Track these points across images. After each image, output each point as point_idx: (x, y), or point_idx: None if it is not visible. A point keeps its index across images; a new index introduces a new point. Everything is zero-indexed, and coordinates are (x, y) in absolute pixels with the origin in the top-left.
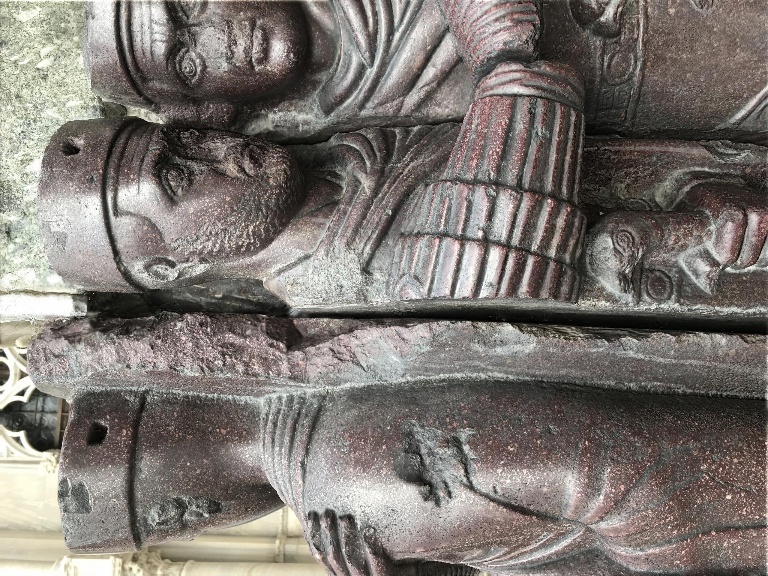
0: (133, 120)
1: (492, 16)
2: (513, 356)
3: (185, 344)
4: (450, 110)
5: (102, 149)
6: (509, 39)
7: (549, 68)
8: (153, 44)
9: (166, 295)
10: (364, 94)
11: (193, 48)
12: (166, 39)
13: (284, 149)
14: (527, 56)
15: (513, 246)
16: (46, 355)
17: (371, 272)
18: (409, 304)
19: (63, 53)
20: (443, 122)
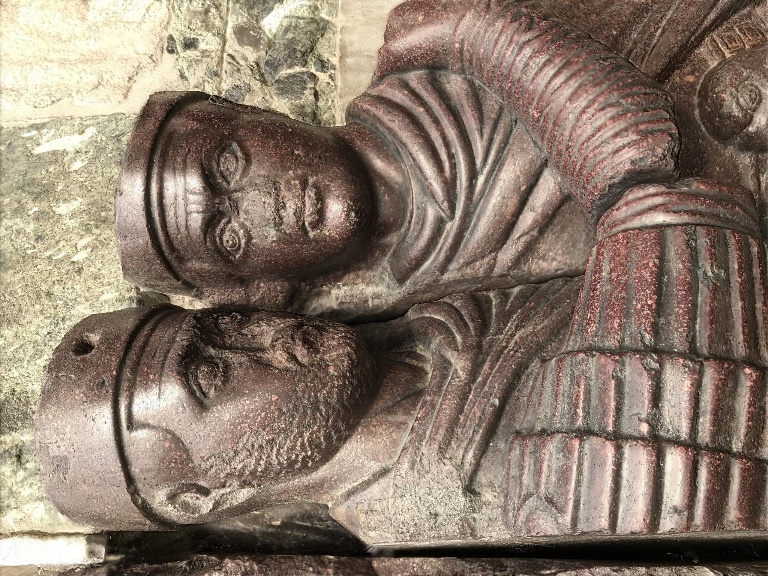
0: (165, 307)
1: (609, 132)
2: None
3: None
4: (559, 262)
5: (119, 345)
6: (638, 156)
7: (704, 186)
8: (188, 217)
9: (211, 524)
10: (446, 253)
11: (236, 218)
12: (203, 209)
13: (347, 327)
14: (665, 176)
15: (702, 445)
16: None
17: (477, 491)
18: (539, 538)
19: (101, 243)
20: (551, 278)
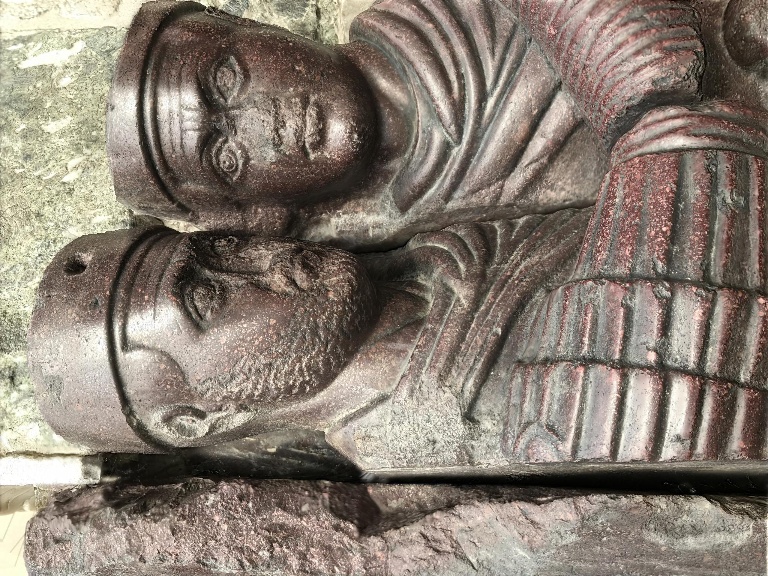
0: (159, 229)
1: (631, 49)
2: (714, 550)
3: (218, 527)
4: (567, 193)
5: (112, 265)
6: (660, 76)
7: (728, 108)
8: (184, 135)
9: (207, 450)
10: (451, 180)
11: (233, 137)
12: (199, 127)
13: (348, 253)
14: (687, 99)
15: (710, 375)
16: (45, 539)
17: (477, 419)
18: (536, 466)
19: (92, 163)
20: (558, 209)
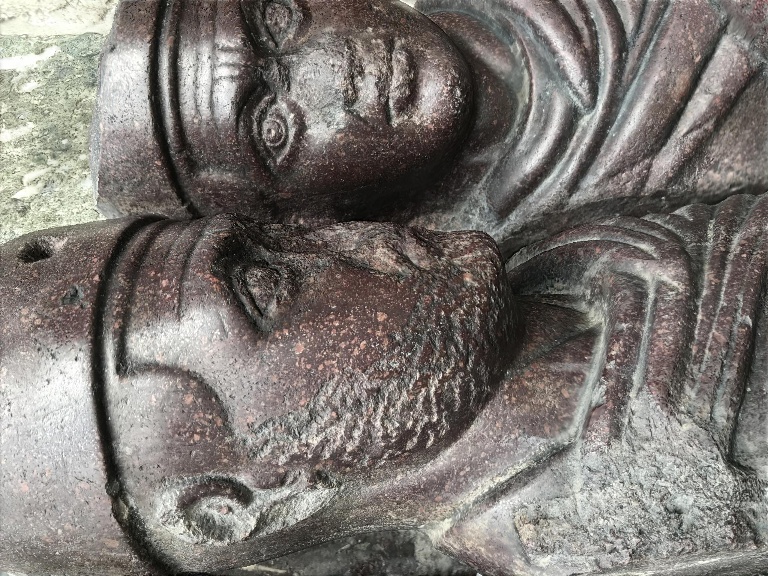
0: None
1: None
2: None
3: None
4: (736, 174)
5: (104, 242)
6: None
7: None
8: (215, 86)
9: None
10: (579, 160)
11: (284, 94)
12: (239, 72)
13: None
14: None
15: None
16: None
17: (746, 465)
18: None
19: (60, 176)
20: (722, 199)
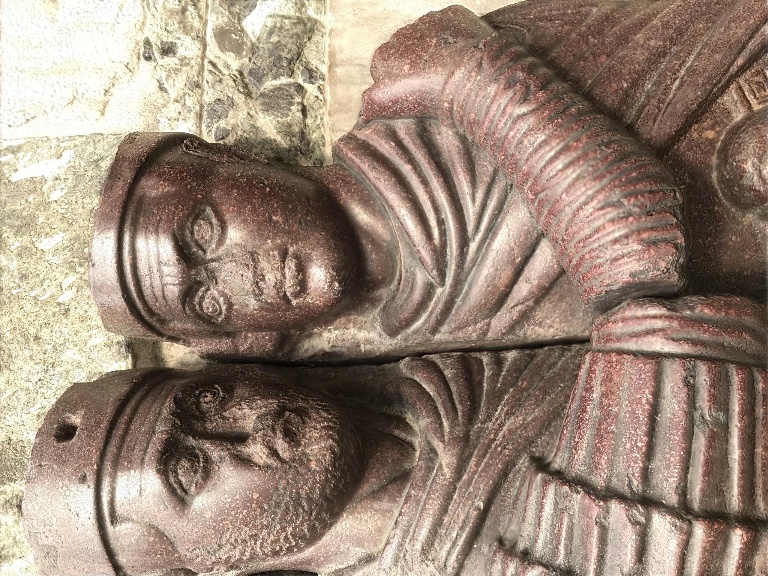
0: (147, 377)
1: (608, 236)
2: None
3: None
4: (556, 330)
5: (99, 434)
6: (638, 268)
7: (708, 309)
8: (165, 288)
9: None
10: (436, 318)
11: (214, 286)
12: (179, 282)
13: (331, 412)
14: (668, 285)
15: None
16: None
17: None
18: None
19: (86, 282)
20: (547, 343)
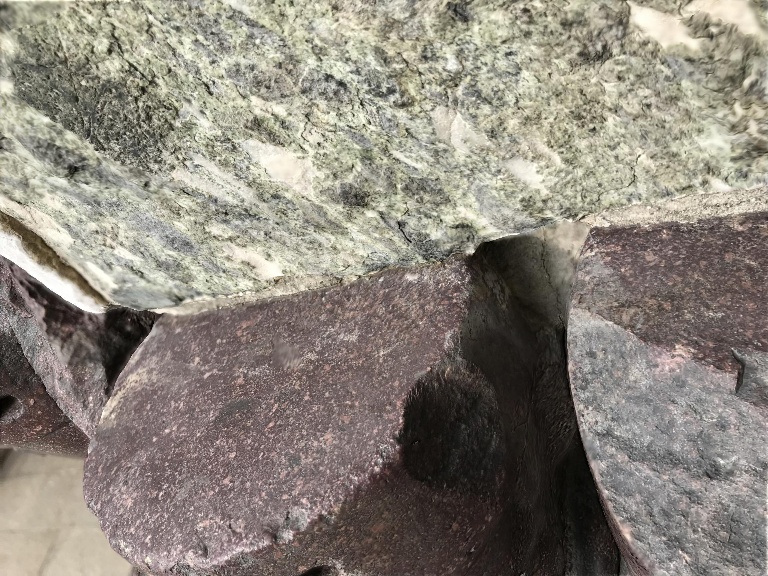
0: None
1: None
2: None
3: None
4: None
5: None
6: None
7: None
8: None
9: None
10: None
11: None
12: None
13: None
14: None
15: None
16: None
17: None
18: None
19: (734, 81)
20: None
